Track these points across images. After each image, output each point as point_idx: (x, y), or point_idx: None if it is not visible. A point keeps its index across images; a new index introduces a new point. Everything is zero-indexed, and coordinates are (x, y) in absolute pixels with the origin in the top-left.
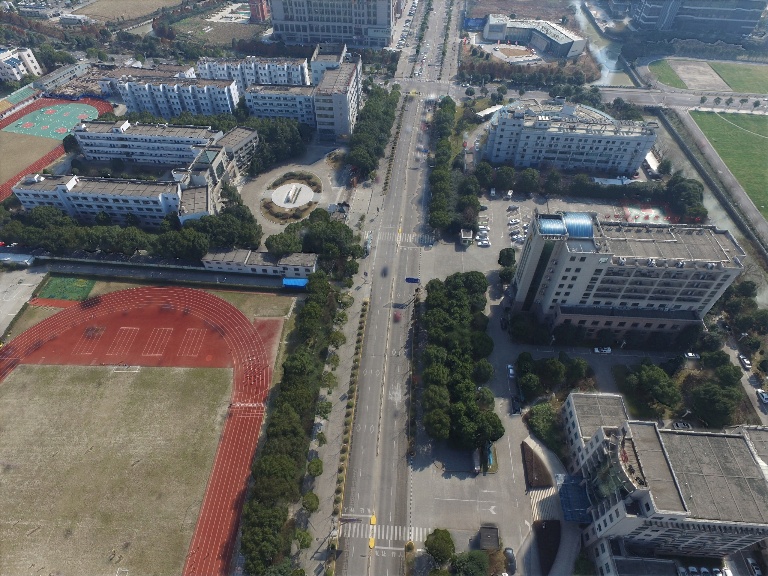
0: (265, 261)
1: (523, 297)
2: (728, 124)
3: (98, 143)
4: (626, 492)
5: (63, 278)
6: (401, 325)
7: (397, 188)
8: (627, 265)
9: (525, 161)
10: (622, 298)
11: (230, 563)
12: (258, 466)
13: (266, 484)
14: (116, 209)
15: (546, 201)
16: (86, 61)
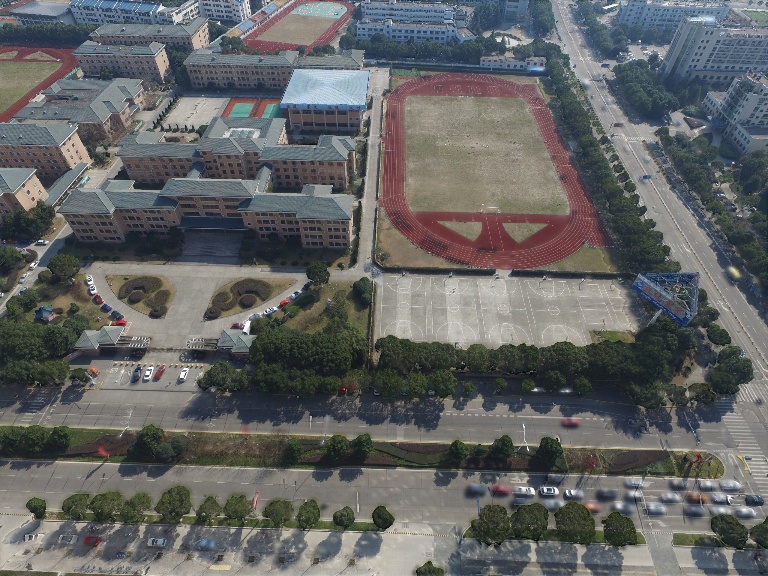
0: (516, 60)
1: (670, 70)
2: (767, 16)
3: (375, 13)
4: (751, 90)
5: (400, 69)
6: (602, 86)
7: (567, 40)
8: (734, 37)
9: (644, 28)
10: (727, 63)
11: (565, 144)
12: (569, 110)
13: (580, 110)
14: (416, 39)
15: (662, 46)
16: None
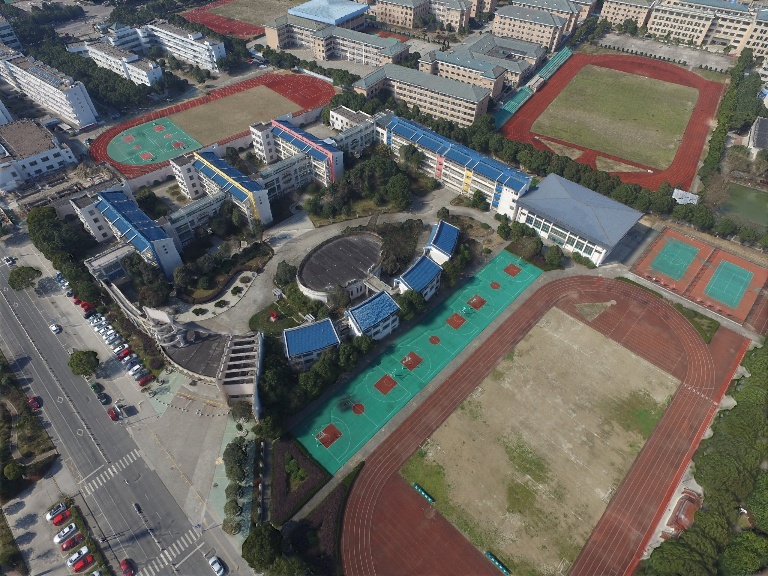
0: None
1: None
2: None
3: None
4: None
5: None
6: None
7: None
8: None
9: None
10: None
11: None
12: None
13: None
14: None
15: None
16: (6, 254)
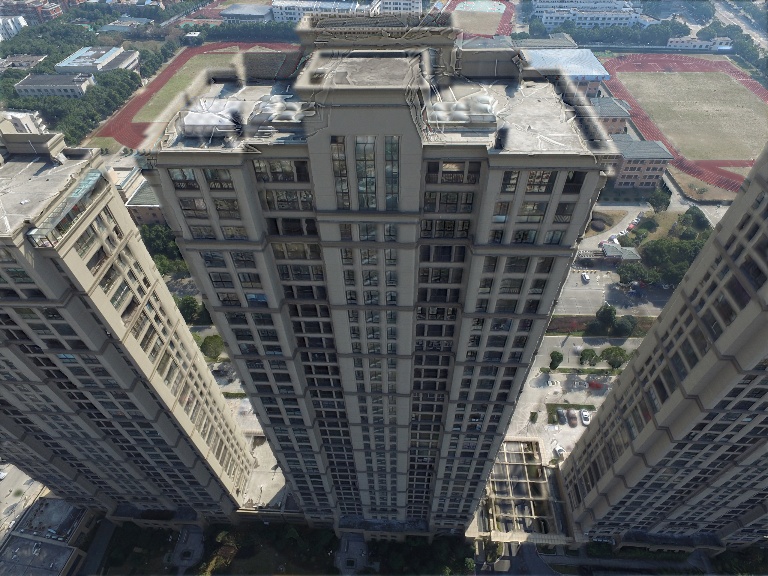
0: None
1: None
2: None
3: (545, 6)
4: None
5: None
6: None
7: None
8: None
9: None
10: None
11: None
12: None
13: None
14: (599, 25)
15: None
16: None
